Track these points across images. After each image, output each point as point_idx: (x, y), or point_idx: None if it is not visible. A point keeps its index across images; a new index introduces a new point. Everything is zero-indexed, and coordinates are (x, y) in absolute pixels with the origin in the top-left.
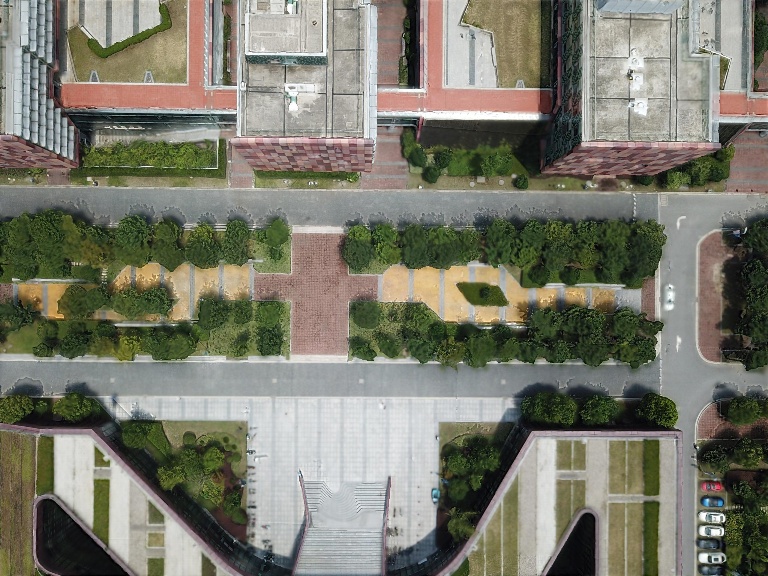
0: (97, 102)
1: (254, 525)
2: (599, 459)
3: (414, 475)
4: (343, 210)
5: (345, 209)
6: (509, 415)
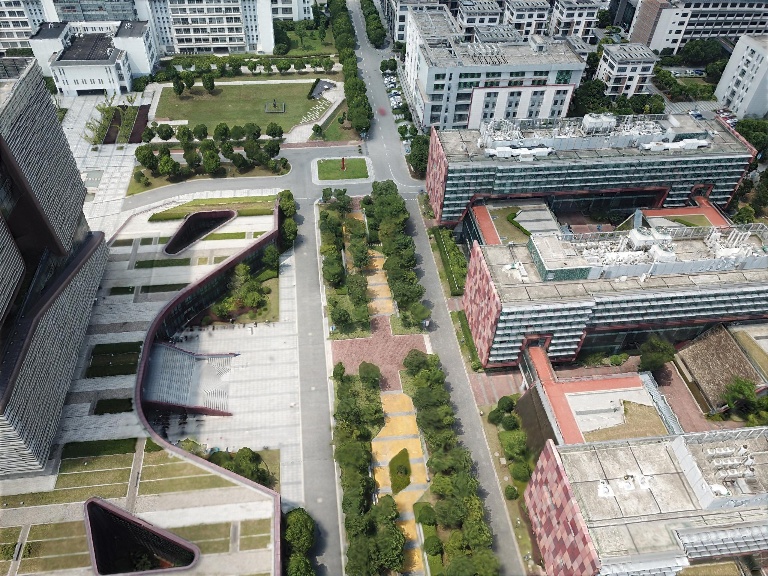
0: (480, 219)
1: (200, 330)
2: (251, 564)
3: (232, 433)
4: (448, 364)
5: (450, 366)
6: (287, 510)
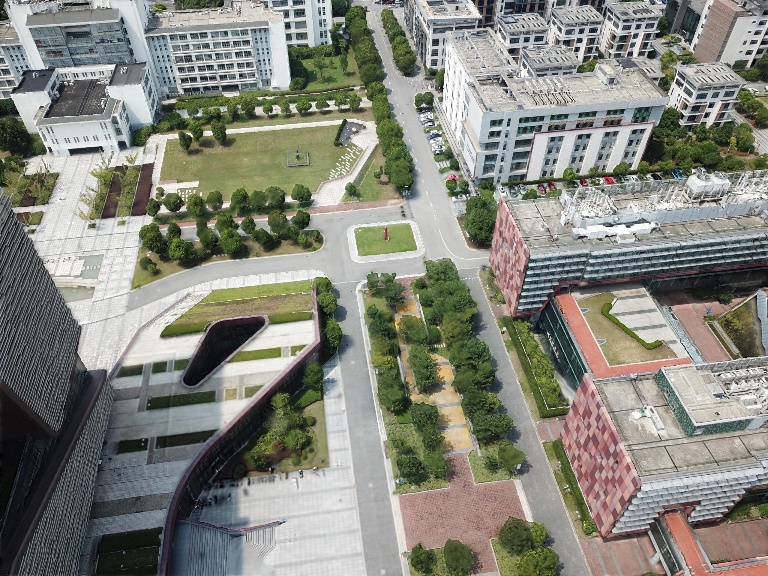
0: (567, 314)
1: (232, 486)
2: None
3: None
4: (552, 525)
5: (553, 527)
6: None
